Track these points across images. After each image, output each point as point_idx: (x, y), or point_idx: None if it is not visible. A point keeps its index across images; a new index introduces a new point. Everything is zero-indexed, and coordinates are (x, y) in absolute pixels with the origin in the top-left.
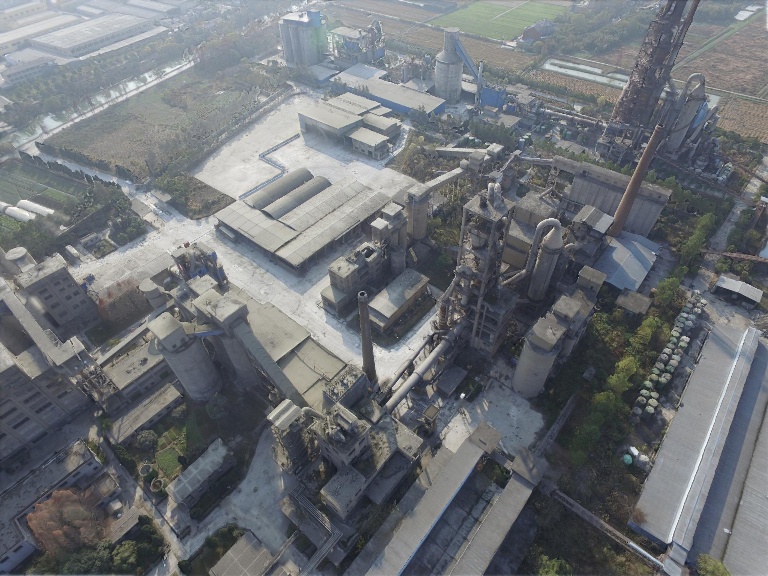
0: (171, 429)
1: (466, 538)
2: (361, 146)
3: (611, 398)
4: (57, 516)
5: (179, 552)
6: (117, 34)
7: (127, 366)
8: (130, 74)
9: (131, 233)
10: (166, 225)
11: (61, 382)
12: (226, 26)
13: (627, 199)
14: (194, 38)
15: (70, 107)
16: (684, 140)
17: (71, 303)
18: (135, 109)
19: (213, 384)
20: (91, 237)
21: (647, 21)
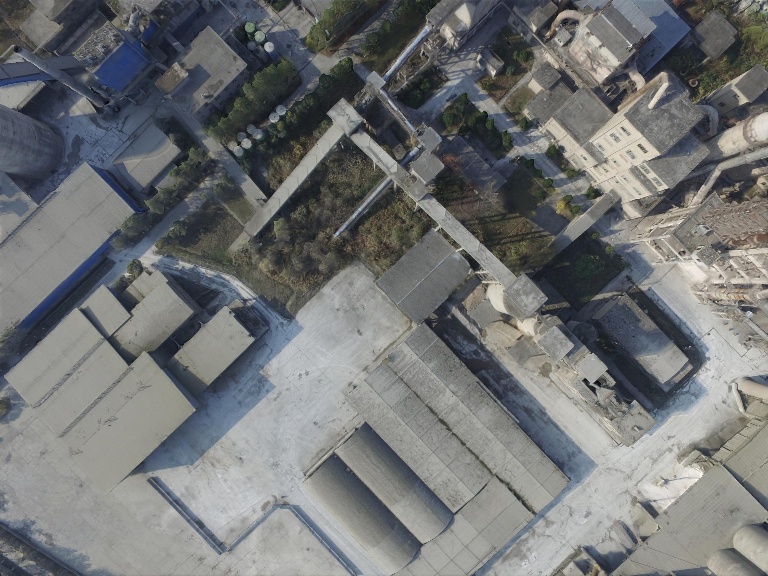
0: None
1: None
2: None
3: None
4: None
5: None
6: None
7: None
8: None
9: None
10: None
11: None
12: None
13: None
14: None
15: None
16: None
17: None
18: None
19: None
20: None
21: None
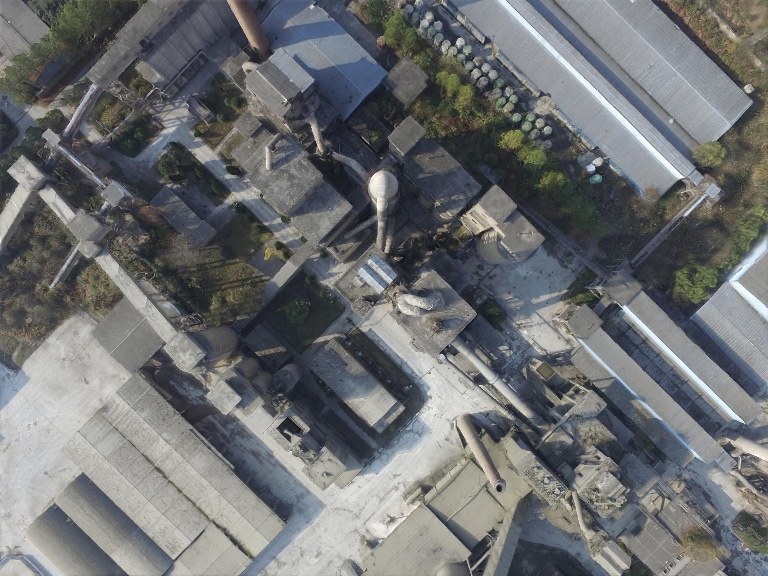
0: None
1: (658, 354)
2: None
3: None
4: None
5: None
6: None
7: None
8: None
9: None
10: None
11: None
12: None
13: (244, 10)
14: None
15: None
16: None
17: None
18: None
19: None
20: None
21: None
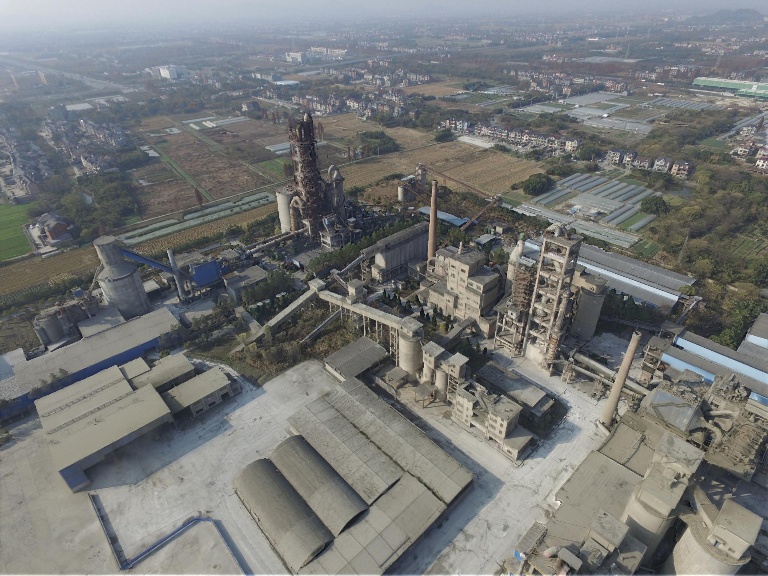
0: None
1: None
2: (208, 401)
3: None
4: None
5: None
6: None
7: None
8: None
9: None
10: None
11: None
12: None
13: (435, 235)
14: None
15: None
16: None
17: None
18: None
19: None
20: None
21: (113, 180)
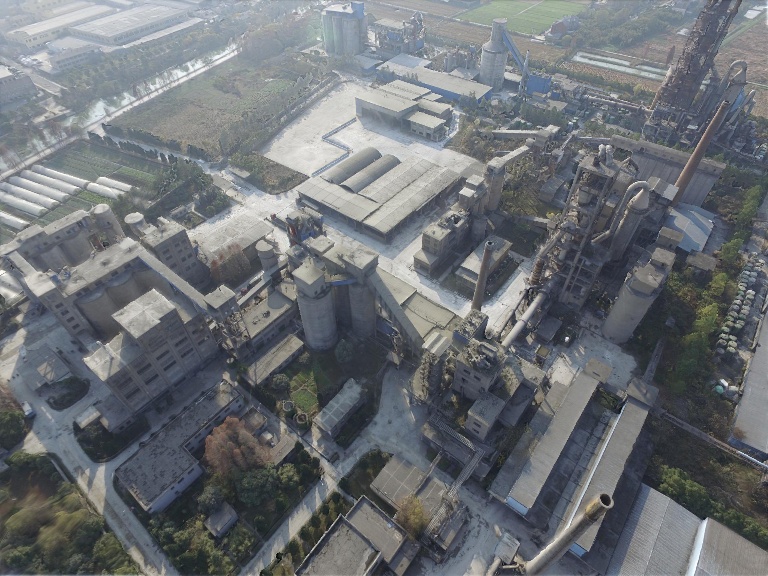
0: (299, 374)
1: (593, 453)
2: (419, 129)
3: (703, 337)
4: (235, 437)
5: (333, 473)
6: (156, 24)
7: (252, 318)
8: (175, 62)
9: (218, 206)
10: (247, 199)
11: (203, 329)
12: (259, 18)
13: (688, 171)
14: (232, 29)
15: (121, 93)
16: (723, 123)
17: (185, 265)
18: (189, 95)
19: (334, 334)
20: (180, 209)
21: (665, 18)
